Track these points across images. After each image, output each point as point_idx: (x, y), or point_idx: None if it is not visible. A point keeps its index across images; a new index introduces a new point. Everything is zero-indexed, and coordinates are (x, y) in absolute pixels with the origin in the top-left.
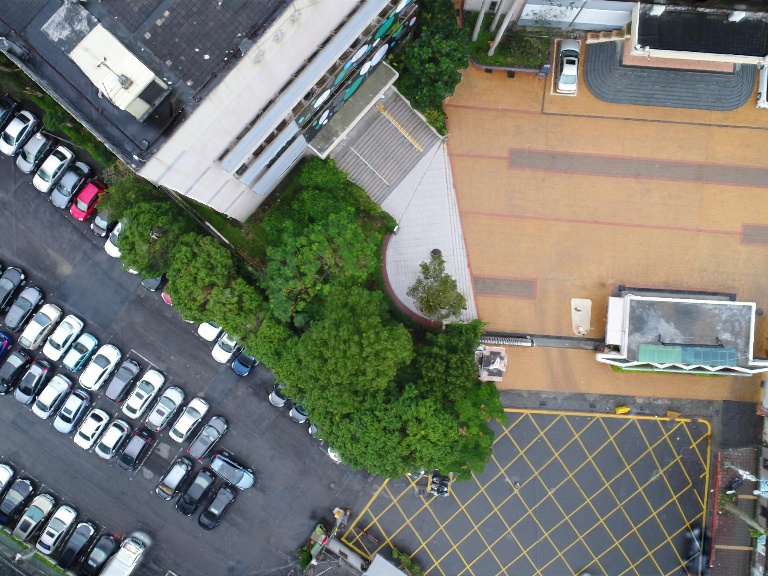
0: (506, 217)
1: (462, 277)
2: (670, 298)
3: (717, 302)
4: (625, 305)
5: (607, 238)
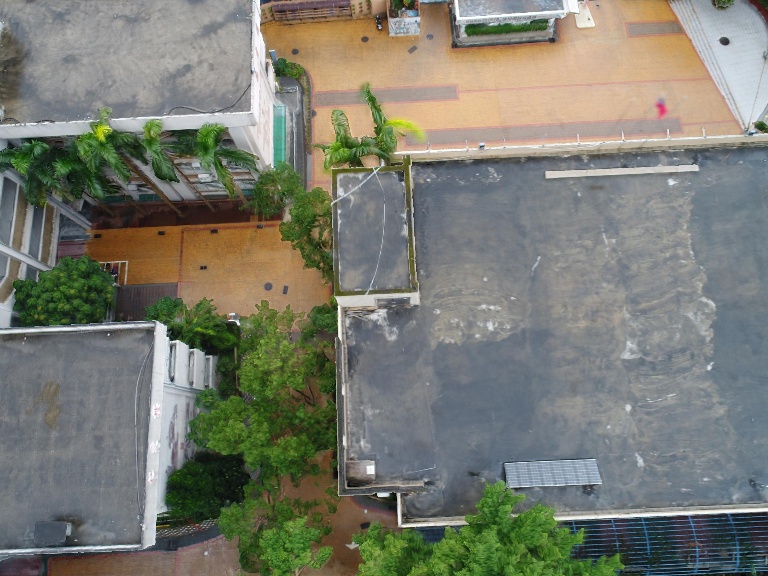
0: (669, 80)
1: (694, 30)
2: (530, 15)
3: (490, 16)
4: (568, 5)
5: (576, 74)
